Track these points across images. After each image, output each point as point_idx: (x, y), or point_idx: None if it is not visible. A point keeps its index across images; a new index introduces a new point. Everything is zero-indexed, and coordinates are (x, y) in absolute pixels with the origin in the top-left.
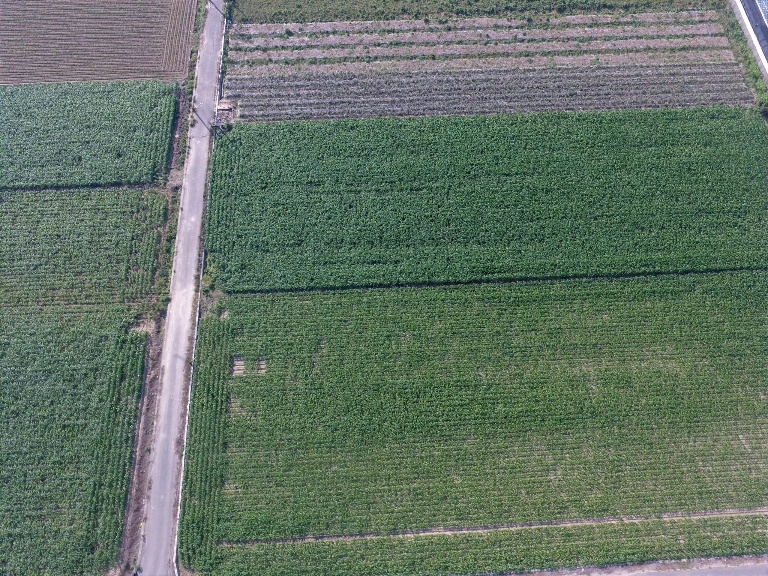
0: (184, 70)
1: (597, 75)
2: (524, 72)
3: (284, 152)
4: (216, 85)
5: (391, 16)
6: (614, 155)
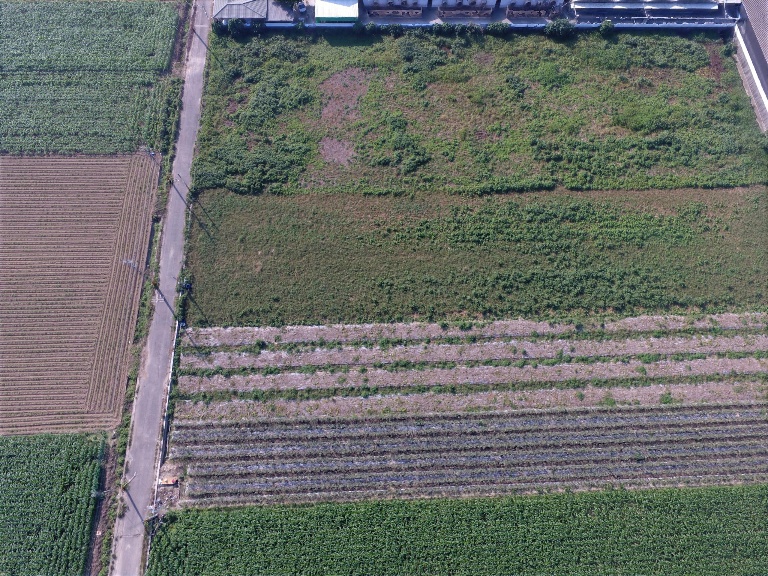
0: (116, 410)
1: (670, 424)
2: (573, 415)
3: (246, 570)
4: (158, 440)
5: (397, 317)
6: (699, 574)
